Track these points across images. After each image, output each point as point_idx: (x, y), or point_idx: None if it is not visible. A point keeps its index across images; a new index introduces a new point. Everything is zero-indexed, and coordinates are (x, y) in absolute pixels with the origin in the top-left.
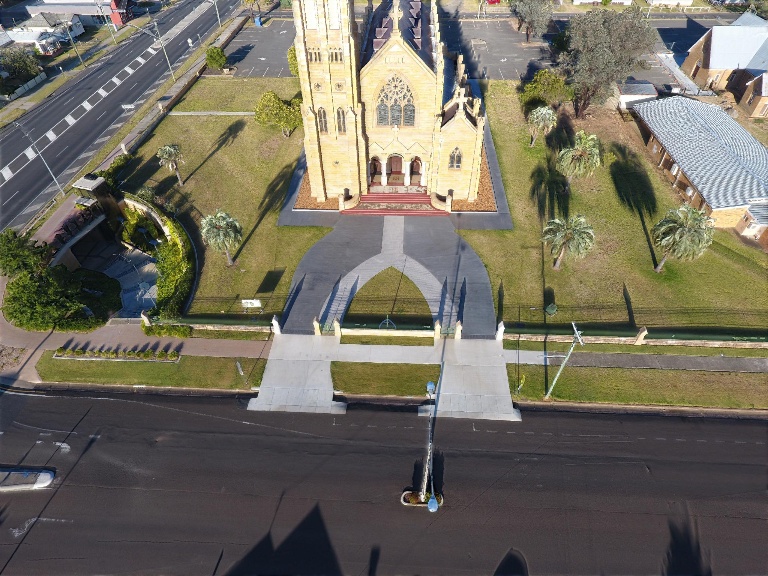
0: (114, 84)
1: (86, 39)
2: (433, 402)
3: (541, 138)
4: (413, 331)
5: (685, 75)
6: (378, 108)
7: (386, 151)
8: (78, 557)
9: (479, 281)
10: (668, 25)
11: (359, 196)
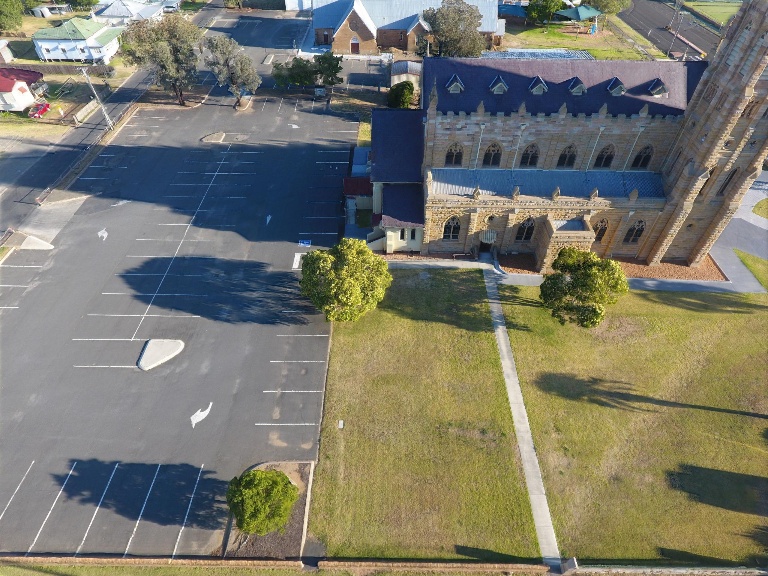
0: None
1: None
2: None
3: None
4: None
5: (371, 51)
6: None
7: None
8: None
9: None
10: None
11: None
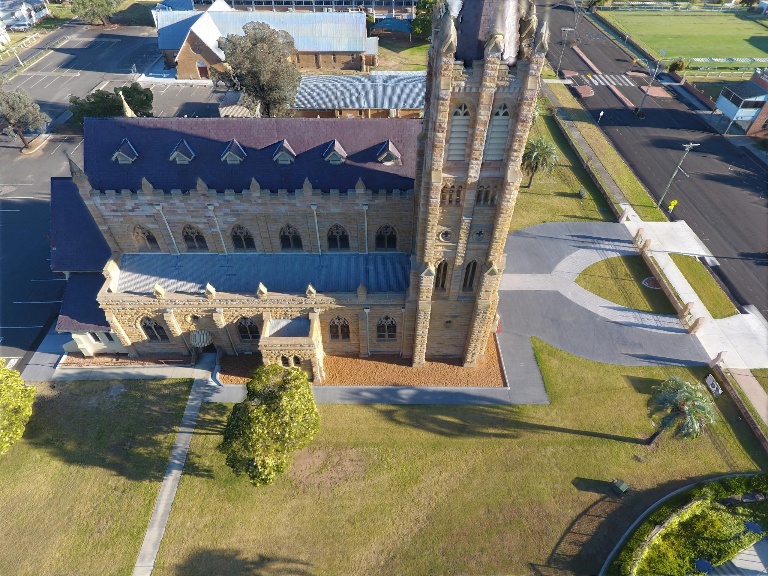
0: None
1: None
2: (701, 259)
3: None
4: None
5: None
6: None
7: None
8: None
9: (565, 227)
10: (59, 61)
11: None
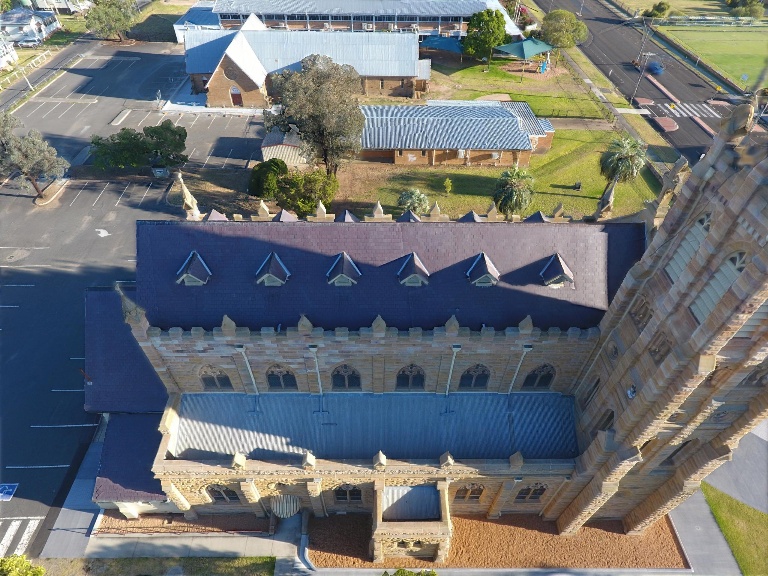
0: None
1: None
2: None
3: None
4: None
5: (253, 105)
6: None
7: None
8: None
9: None
10: (73, 84)
11: None
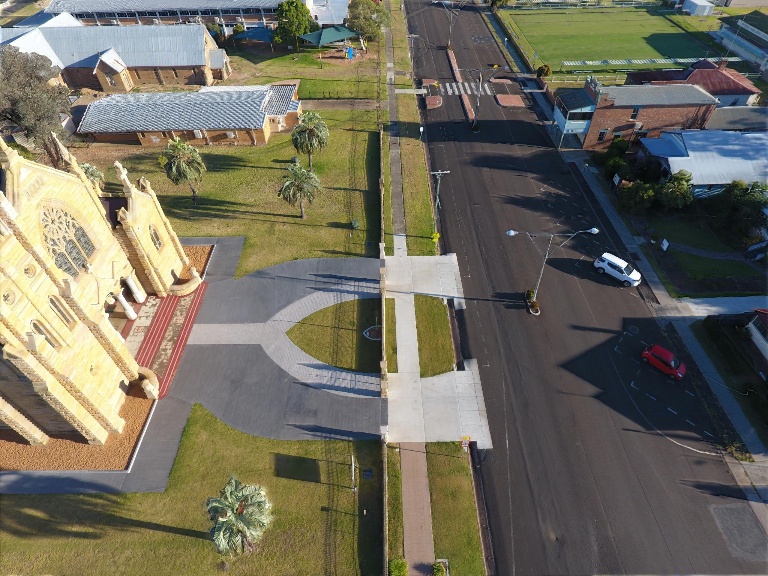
0: None
1: None
2: (450, 301)
3: None
4: None
5: None
6: (56, 265)
7: (100, 303)
8: (693, 571)
9: (315, 265)
10: None
11: None
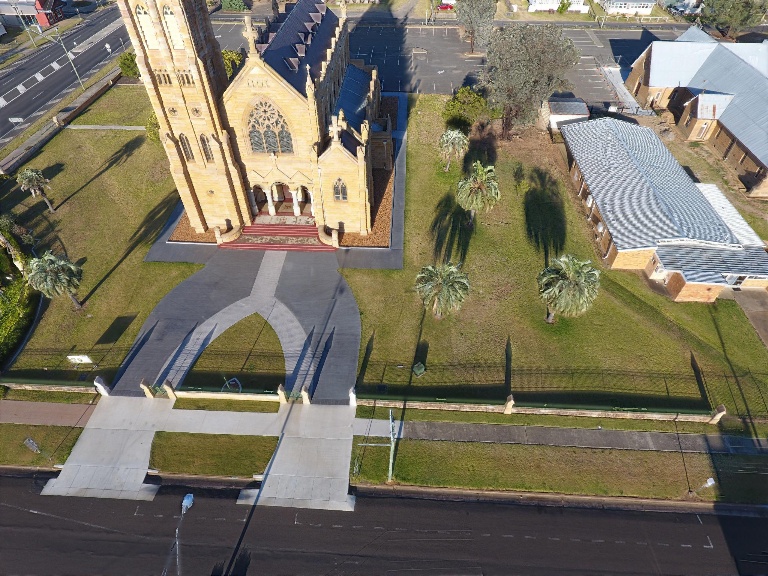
0: (17, 92)
1: (6, 41)
2: (259, 485)
3: (459, 161)
4: (255, 395)
5: (625, 92)
6: (251, 134)
7: (267, 180)
8: None
9: (349, 332)
10: (621, 36)
11: (240, 228)
